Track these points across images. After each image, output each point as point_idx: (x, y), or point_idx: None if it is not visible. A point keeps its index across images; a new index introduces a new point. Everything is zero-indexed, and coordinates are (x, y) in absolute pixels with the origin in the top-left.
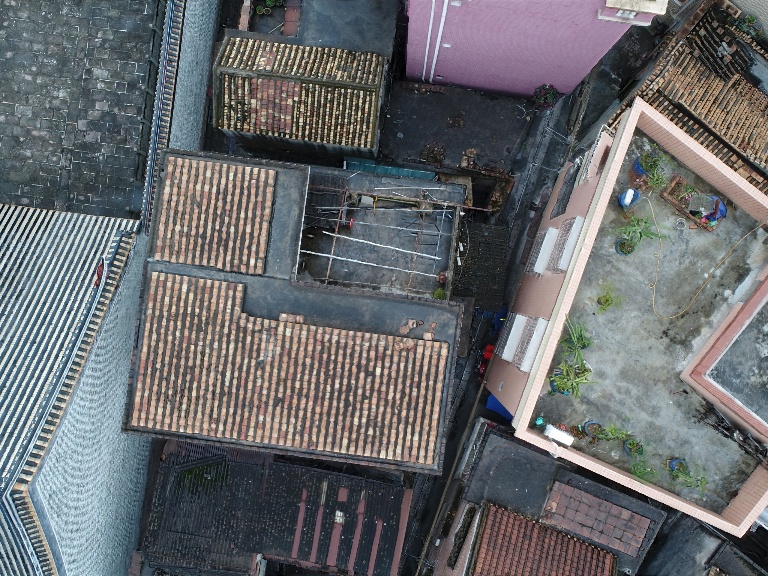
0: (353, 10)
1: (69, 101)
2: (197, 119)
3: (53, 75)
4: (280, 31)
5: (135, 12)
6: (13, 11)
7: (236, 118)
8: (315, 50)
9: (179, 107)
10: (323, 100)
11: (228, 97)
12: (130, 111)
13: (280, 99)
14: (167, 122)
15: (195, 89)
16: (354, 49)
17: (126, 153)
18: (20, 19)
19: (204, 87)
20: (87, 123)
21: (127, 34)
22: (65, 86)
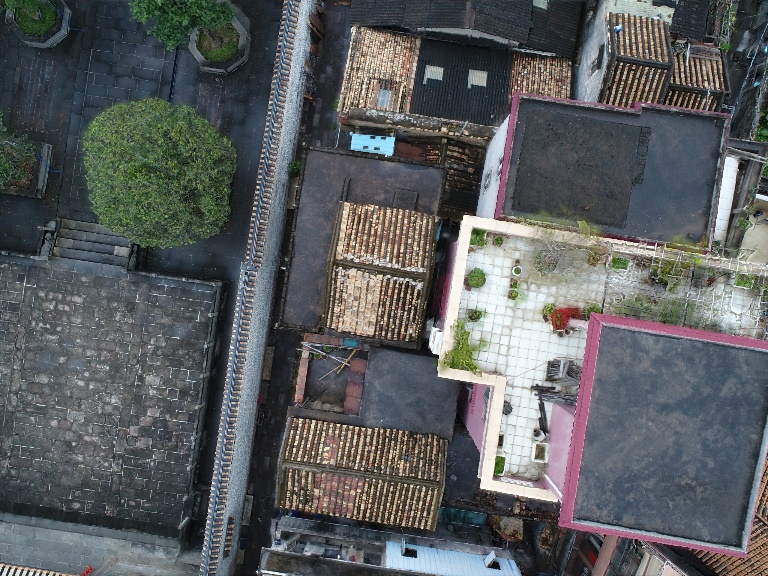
0: (415, 391)
1: (121, 407)
2: (249, 435)
3: (106, 381)
4: (336, 374)
5: (188, 319)
6: (67, 316)
7: (298, 501)
8: (377, 433)
9: (236, 451)
10: (385, 491)
11: (291, 485)
12: (181, 418)
13: (343, 490)
14: (227, 482)
15: (249, 413)
16: (415, 430)
17: (177, 459)
18: (73, 324)
19: (256, 399)
20: (139, 429)
21: (180, 341)
22: (117, 392)
